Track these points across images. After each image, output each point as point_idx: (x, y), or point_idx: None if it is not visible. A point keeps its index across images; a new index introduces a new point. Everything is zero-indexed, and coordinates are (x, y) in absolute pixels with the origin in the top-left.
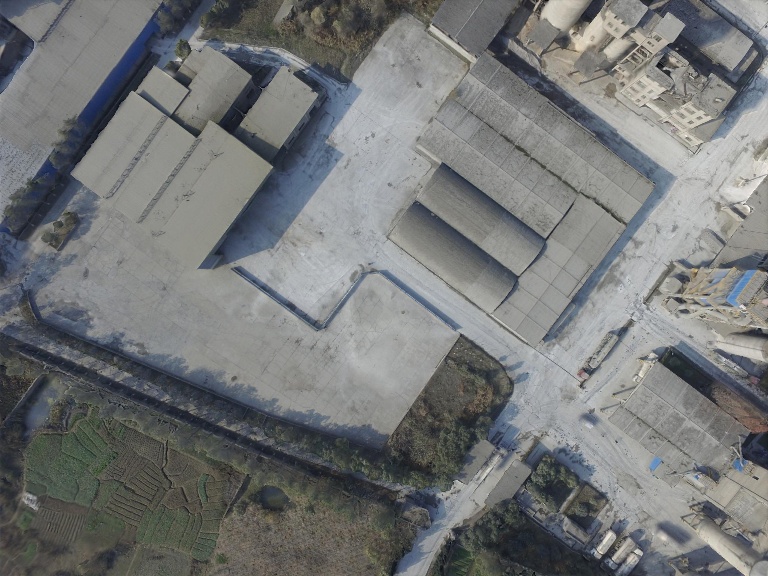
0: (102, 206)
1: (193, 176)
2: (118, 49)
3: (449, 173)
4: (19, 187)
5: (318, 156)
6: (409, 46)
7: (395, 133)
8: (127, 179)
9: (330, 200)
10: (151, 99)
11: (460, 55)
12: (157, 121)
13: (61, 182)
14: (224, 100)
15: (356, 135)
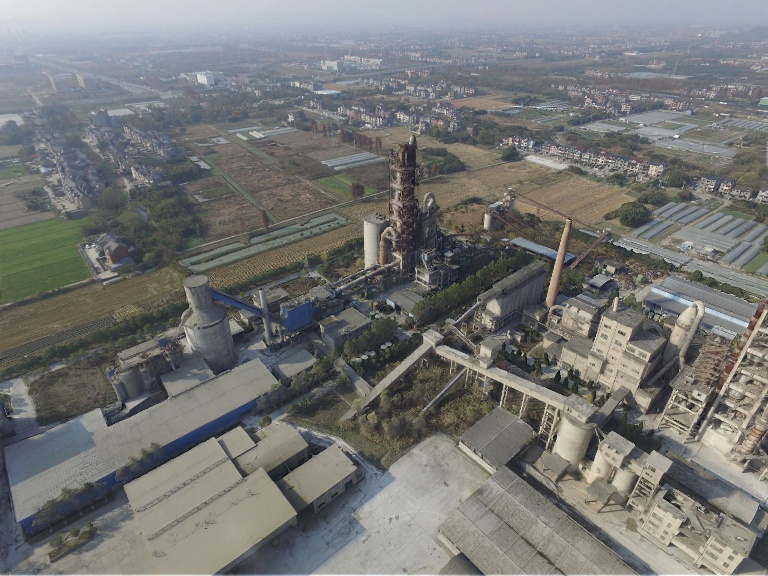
0: (124, 527)
1: (223, 508)
2: (221, 411)
3: (467, 564)
4: (74, 488)
5: (341, 525)
6: (441, 454)
7: (418, 520)
8: (166, 499)
9: (339, 572)
10: (224, 446)
11: (484, 469)
12: (220, 459)
13: (107, 498)
14: (279, 457)
15: (381, 514)
